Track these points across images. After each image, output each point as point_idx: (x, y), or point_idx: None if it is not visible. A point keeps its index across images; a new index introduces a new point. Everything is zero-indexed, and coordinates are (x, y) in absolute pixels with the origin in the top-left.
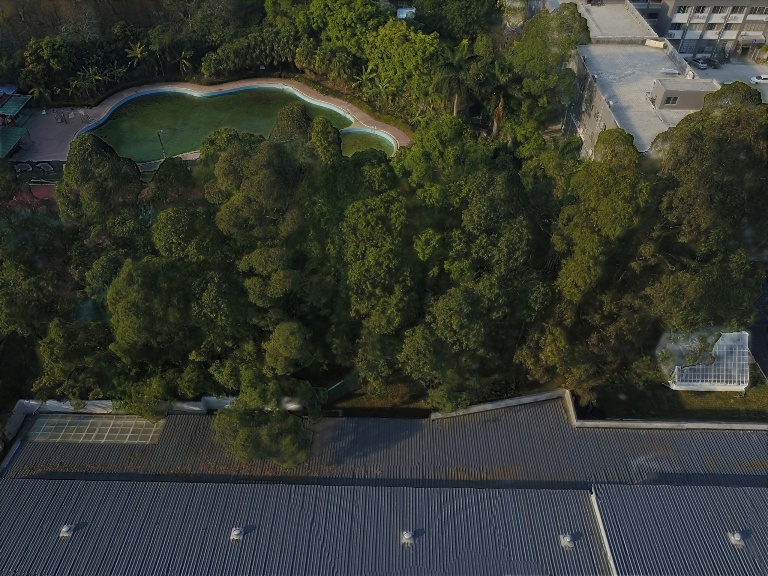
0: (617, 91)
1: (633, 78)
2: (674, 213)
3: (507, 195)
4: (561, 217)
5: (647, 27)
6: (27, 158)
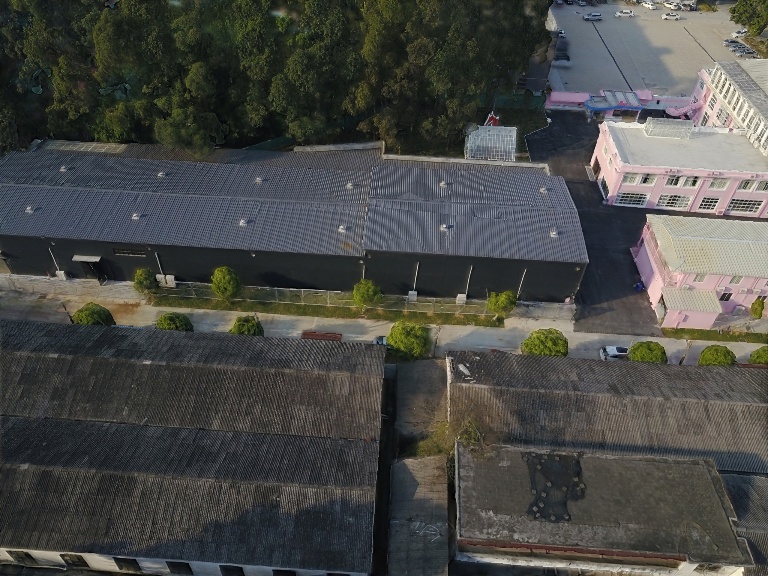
0: None
1: None
2: (422, 3)
3: None
4: (364, 9)
5: None
6: None
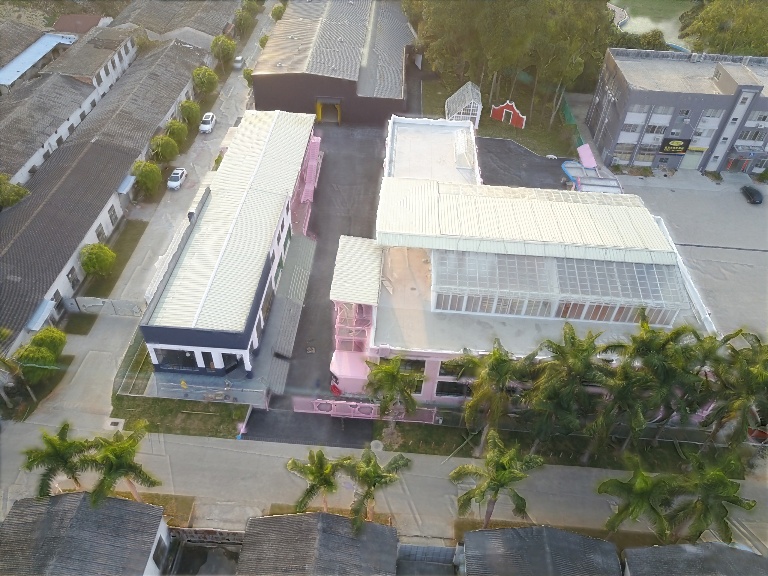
0: None
1: None
2: None
3: None
4: None
5: None
6: None
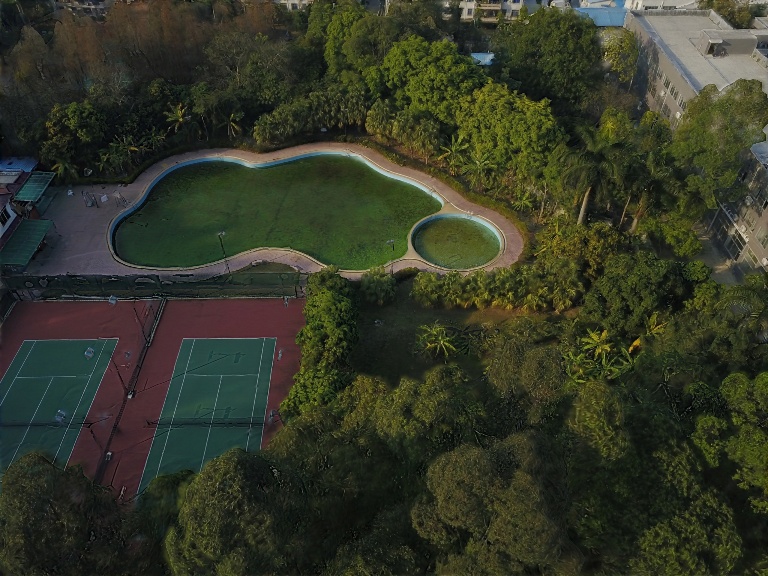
0: None
1: None
2: None
3: None
4: None
5: None
6: (54, 259)
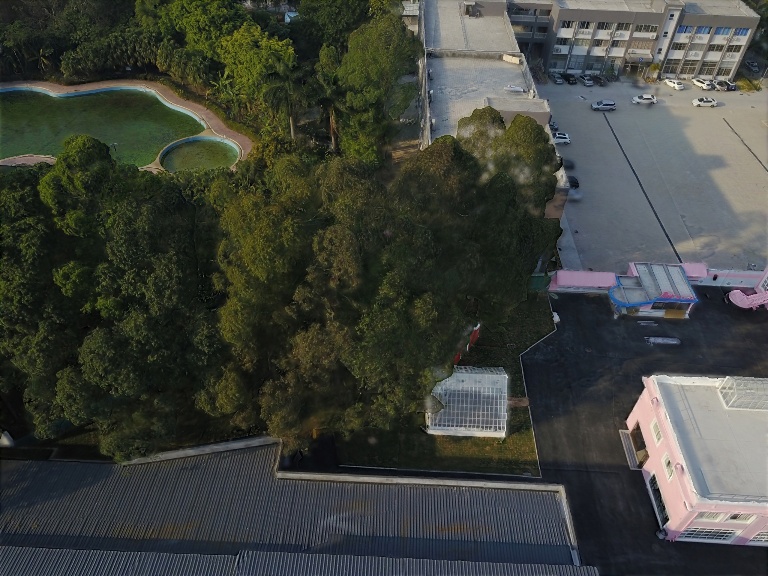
0: (452, 108)
1: (474, 95)
2: (322, 254)
3: (157, 227)
4: (219, 253)
5: (514, 41)
6: None
